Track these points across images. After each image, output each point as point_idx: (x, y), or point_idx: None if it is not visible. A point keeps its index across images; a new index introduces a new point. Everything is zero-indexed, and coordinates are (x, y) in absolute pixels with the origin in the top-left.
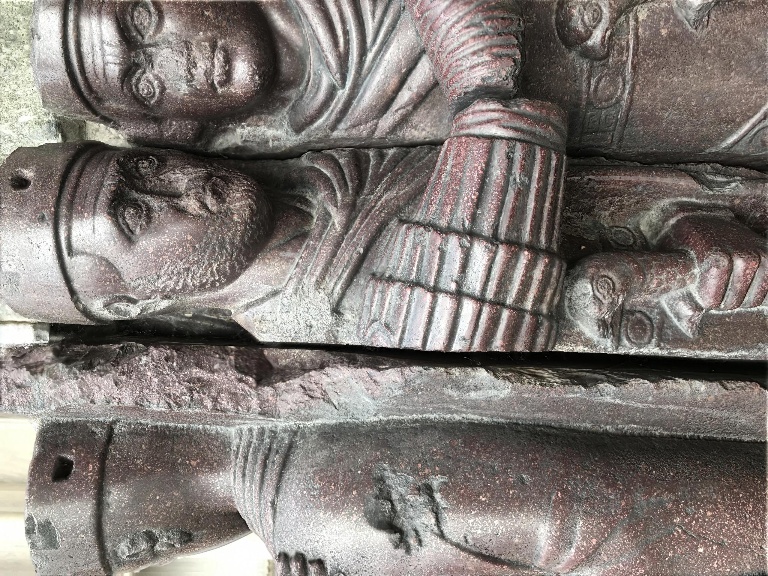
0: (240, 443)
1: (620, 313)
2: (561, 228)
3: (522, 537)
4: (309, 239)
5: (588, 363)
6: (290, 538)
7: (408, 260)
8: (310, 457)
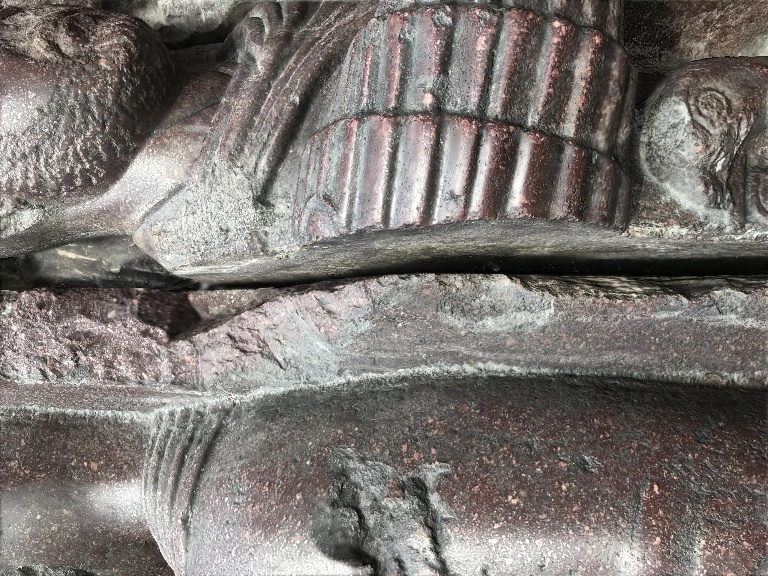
0: (157, 433)
1: (742, 169)
2: (623, 15)
3: (590, 570)
4: (222, 97)
5: (690, 274)
6: (205, 575)
7: (357, 84)
8: (239, 444)
